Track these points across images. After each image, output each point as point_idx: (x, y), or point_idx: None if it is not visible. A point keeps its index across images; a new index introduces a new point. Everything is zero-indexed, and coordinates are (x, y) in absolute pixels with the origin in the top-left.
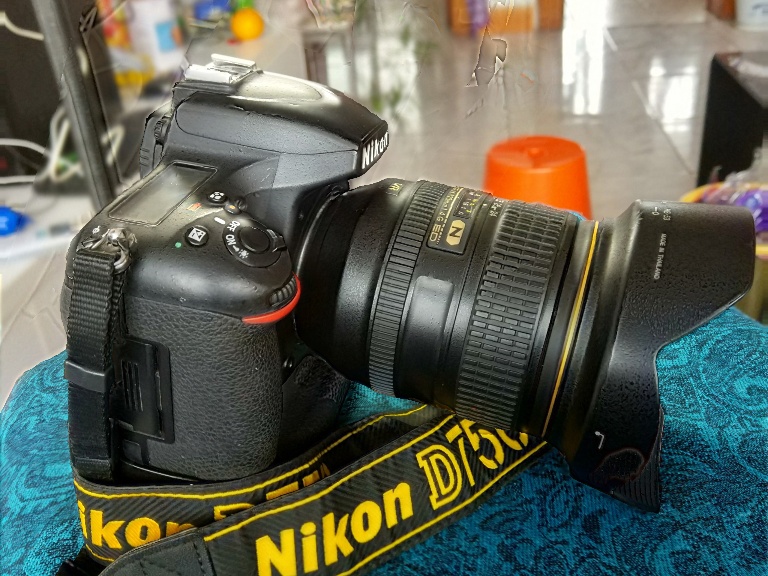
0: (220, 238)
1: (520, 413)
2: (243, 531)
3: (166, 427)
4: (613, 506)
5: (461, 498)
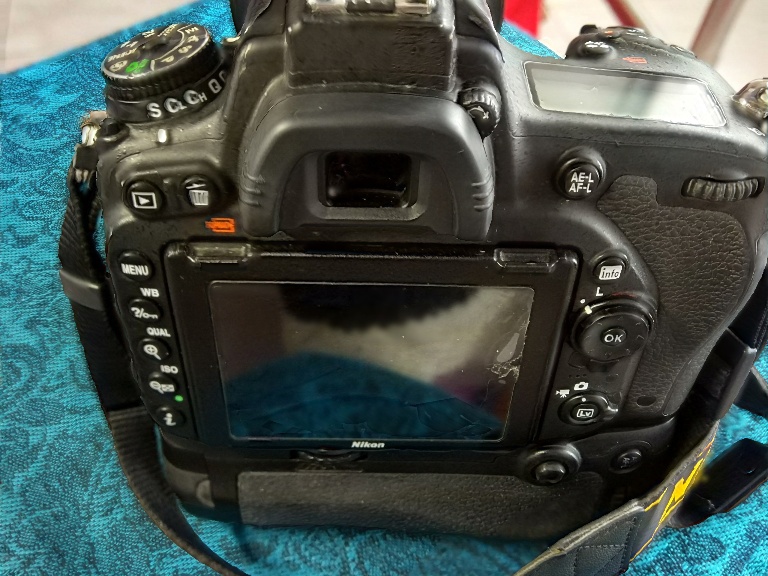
0: None
1: None
2: None
3: None
4: None
5: None
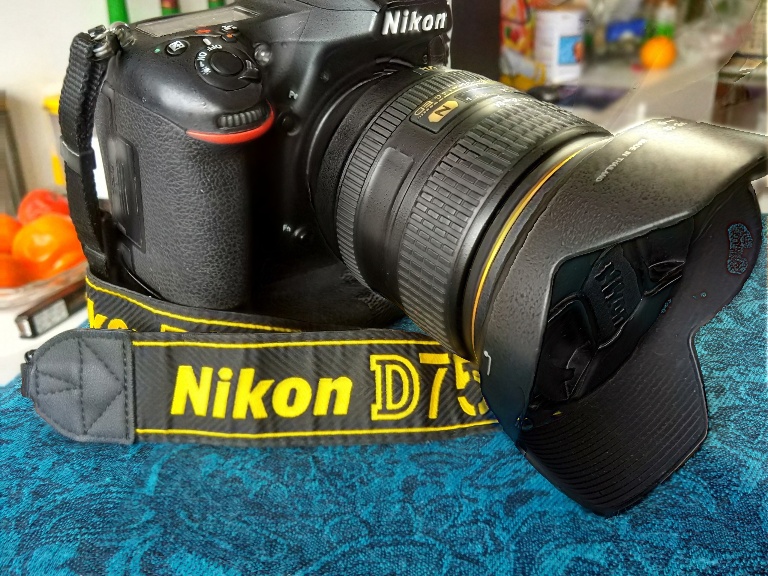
0: (195, 54)
1: (451, 326)
2: (169, 351)
3: (142, 235)
4: (561, 493)
5: (408, 422)
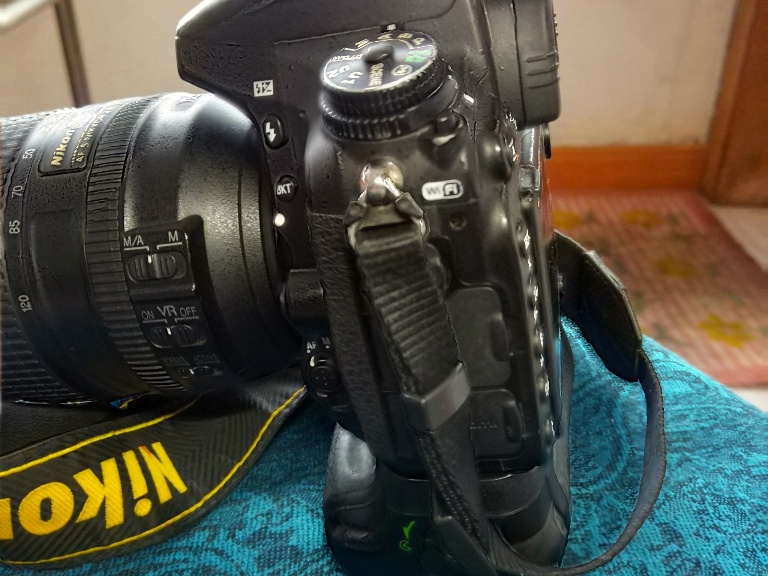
0: None
1: None
2: None
3: None
4: None
5: None
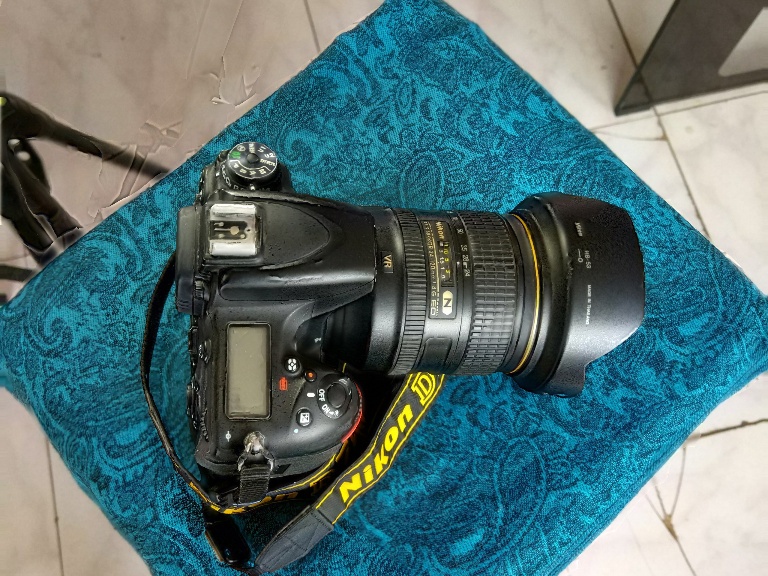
0: (318, 411)
1: None
2: None
3: None
4: None
5: None
